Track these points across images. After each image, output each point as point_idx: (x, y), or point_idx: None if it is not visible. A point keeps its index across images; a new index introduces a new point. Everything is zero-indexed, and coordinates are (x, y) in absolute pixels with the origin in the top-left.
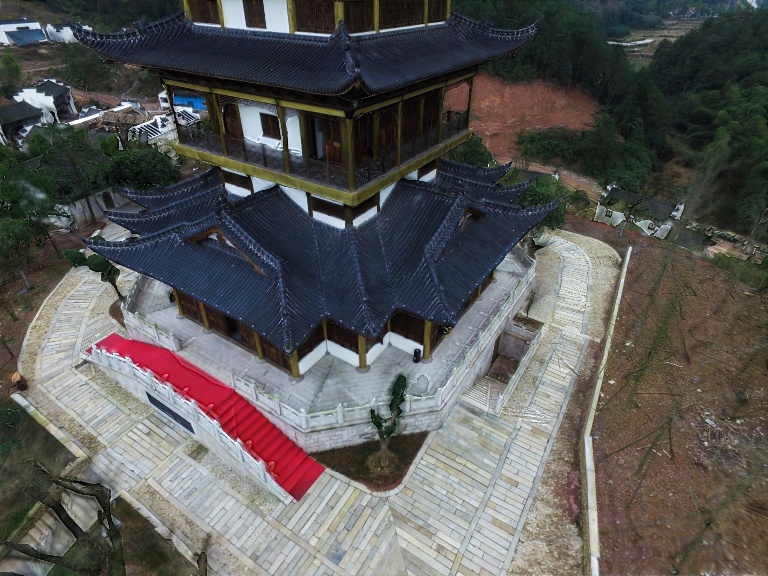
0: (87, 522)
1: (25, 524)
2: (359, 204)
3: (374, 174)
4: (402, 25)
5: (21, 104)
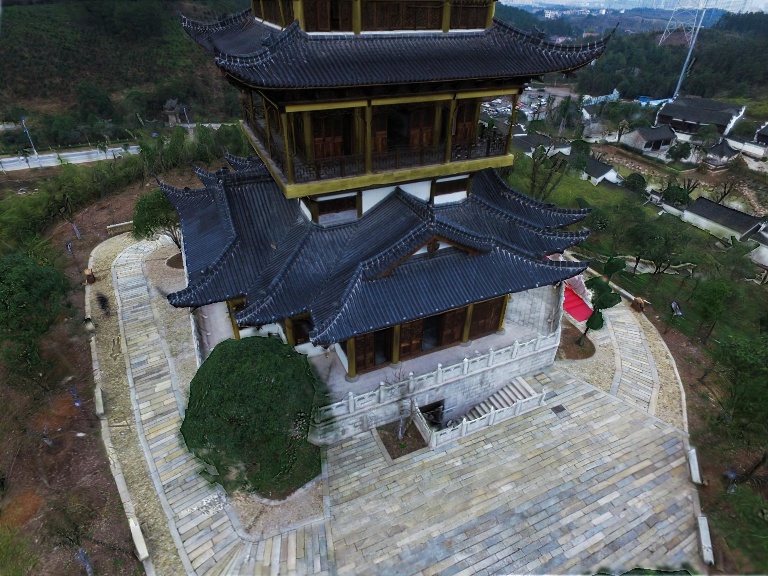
0: None
1: None
2: None
3: None
4: None
5: None
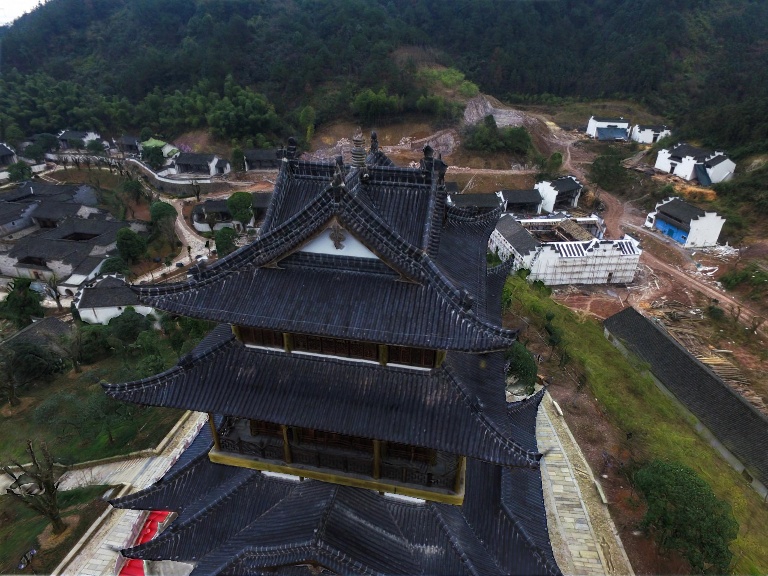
0: (121, 481)
1: (127, 456)
2: (217, 463)
3: (249, 452)
4: (336, 354)
5: (534, 191)
